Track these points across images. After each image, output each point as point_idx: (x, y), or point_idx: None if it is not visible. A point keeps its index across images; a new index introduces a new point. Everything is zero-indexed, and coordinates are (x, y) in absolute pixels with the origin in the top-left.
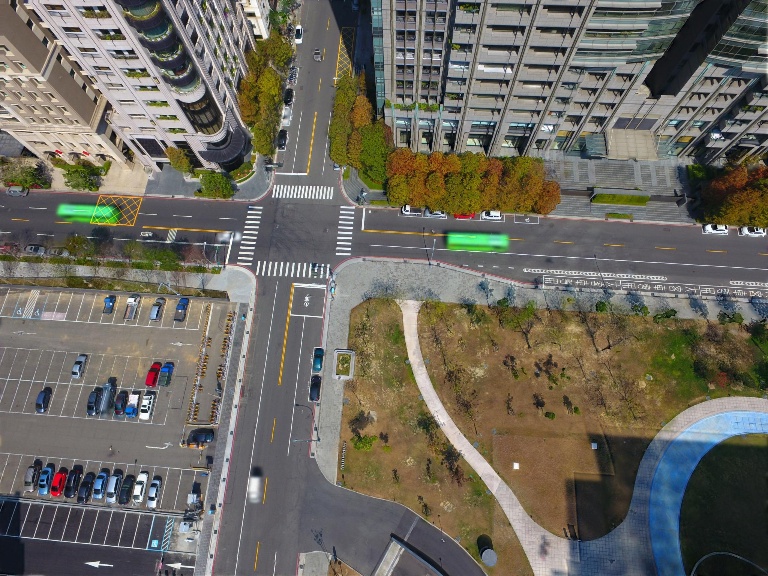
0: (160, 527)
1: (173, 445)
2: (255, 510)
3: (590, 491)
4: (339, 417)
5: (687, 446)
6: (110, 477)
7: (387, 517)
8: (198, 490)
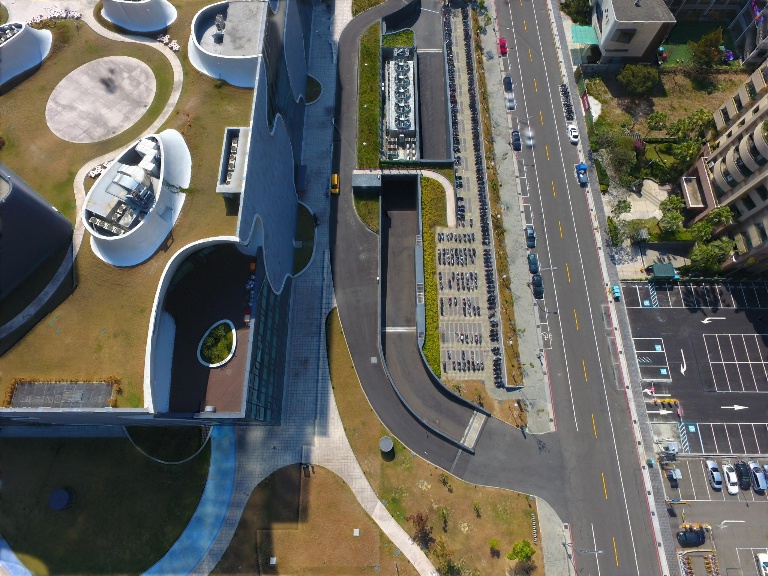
0: (694, 443)
1: (717, 526)
2: (609, 466)
3: (284, 512)
4: (548, 573)
5: (176, 568)
6: (767, 487)
7: (480, 470)
8: (672, 481)
